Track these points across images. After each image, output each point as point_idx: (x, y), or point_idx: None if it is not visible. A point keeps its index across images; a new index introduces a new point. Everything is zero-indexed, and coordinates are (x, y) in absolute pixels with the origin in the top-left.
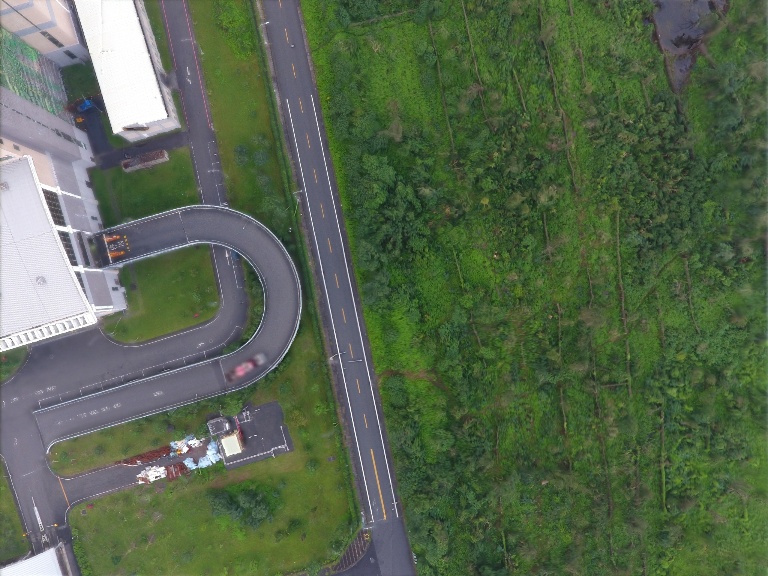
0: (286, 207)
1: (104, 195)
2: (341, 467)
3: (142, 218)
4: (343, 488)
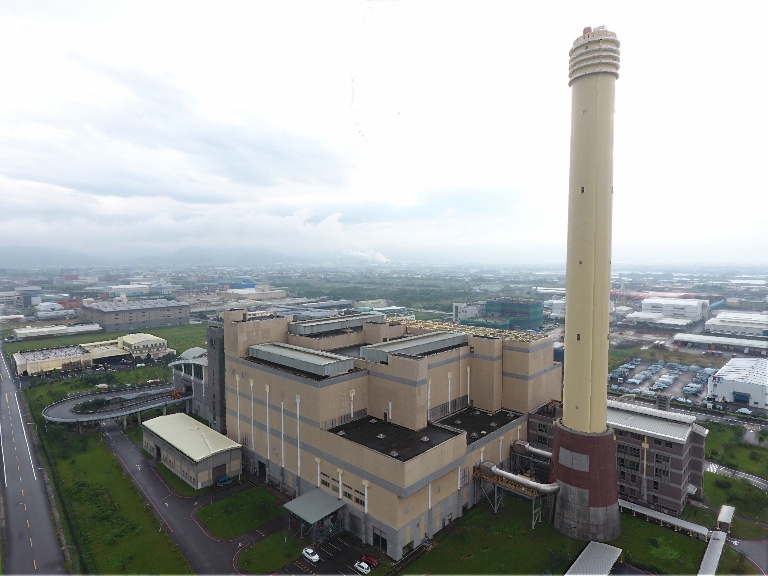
0: (49, 438)
1: (200, 421)
2: (31, 394)
3: (159, 404)
4: (31, 390)
